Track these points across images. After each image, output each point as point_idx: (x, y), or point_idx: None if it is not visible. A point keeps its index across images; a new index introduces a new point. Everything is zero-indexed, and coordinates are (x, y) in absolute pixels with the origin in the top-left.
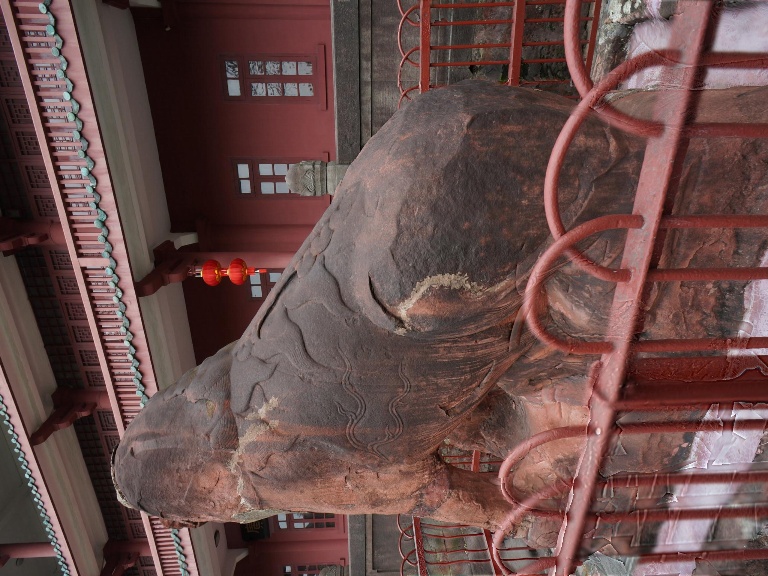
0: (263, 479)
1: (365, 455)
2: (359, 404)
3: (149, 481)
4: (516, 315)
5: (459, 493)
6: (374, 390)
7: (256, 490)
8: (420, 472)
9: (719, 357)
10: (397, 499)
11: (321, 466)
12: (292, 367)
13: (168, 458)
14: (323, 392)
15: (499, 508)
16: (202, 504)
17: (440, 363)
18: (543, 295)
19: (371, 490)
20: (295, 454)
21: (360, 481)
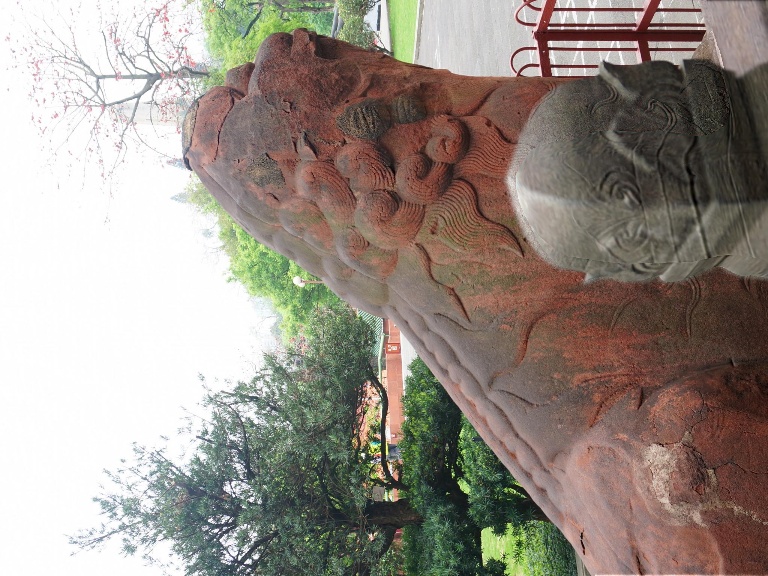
0: None
1: None
2: None
3: None
4: None
5: None
6: None
7: None
8: None
9: None
10: None
11: None
12: None
13: None
14: None
15: None
16: None
17: None
18: None
19: None
20: None
21: None
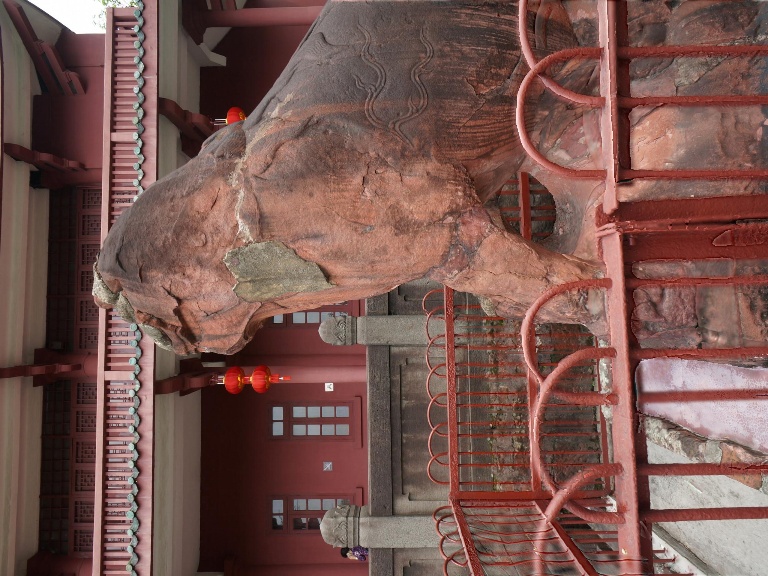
0: (267, 181)
1: (386, 136)
2: (379, 74)
3: (137, 218)
4: (537, 9)
5: (504, 233)
6: (395, 57)
7: (258, 200)
8: (452, 184)
9: (764, 1)
10: (426, 222)
11: (335, 158)
12: (310, 61)
13: (164, 188)
14: (341, 68)
15: (558, 260)
16: (191, 239)
17: (463, 28)
18: (563, 10)
19: (394, 202)
20: (306, 141)
21: (380, 185)
